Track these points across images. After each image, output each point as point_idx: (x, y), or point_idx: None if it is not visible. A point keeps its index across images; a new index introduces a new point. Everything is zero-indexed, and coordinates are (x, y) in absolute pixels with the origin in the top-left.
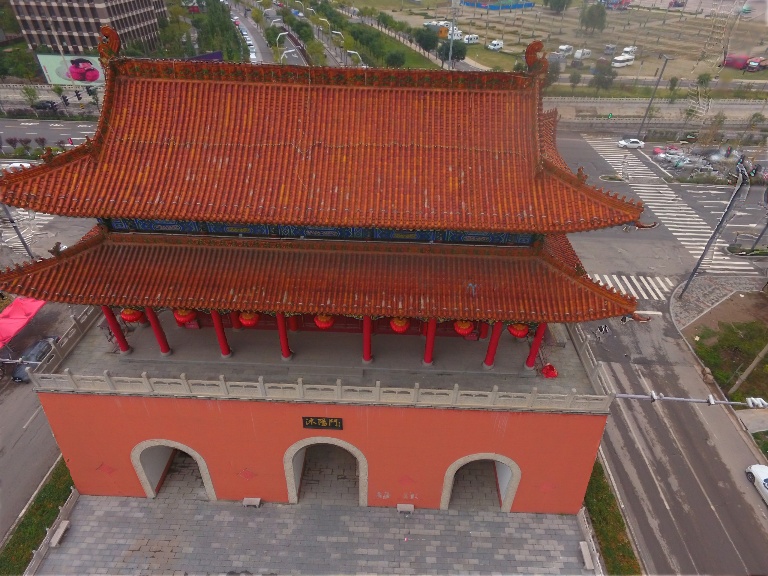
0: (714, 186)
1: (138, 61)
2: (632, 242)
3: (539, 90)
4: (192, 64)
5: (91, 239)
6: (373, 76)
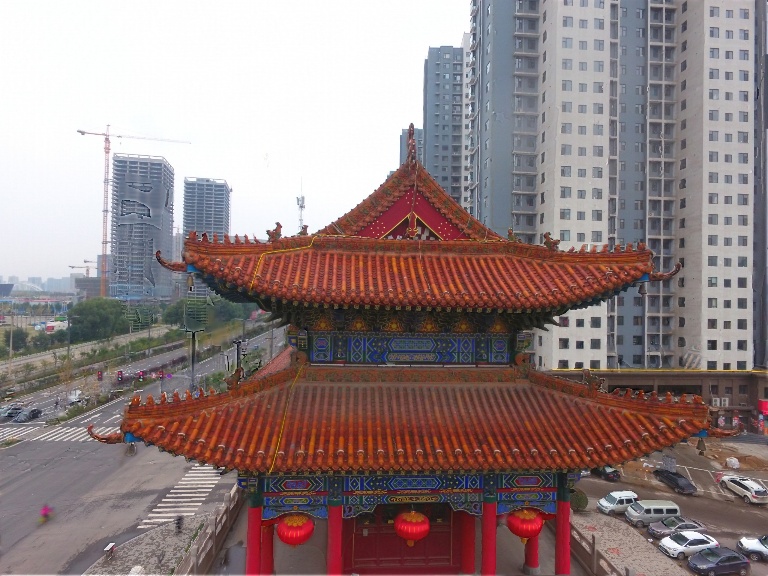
0: (88, 413)
1: None
2: (143, 456)
3: None
4: None
5: (544, 374)
6: None
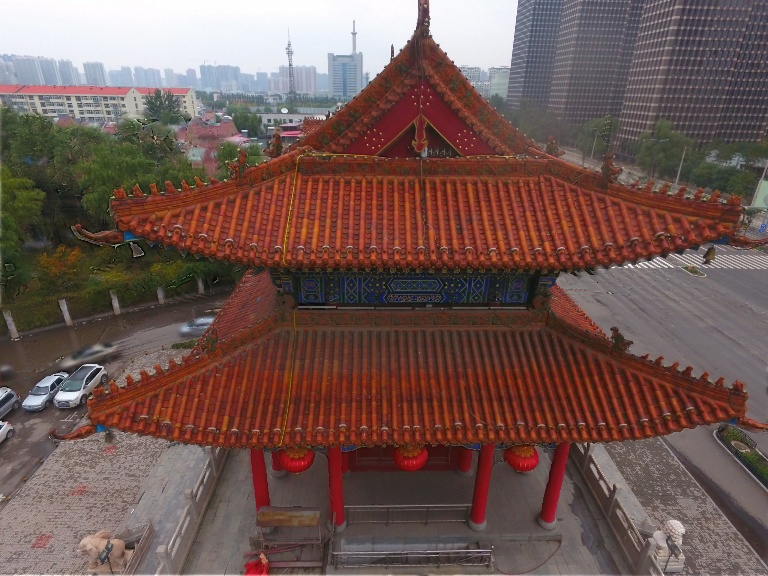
0: None
1: None
2: None
3: (417, 60)
4: None
5: None
6: None
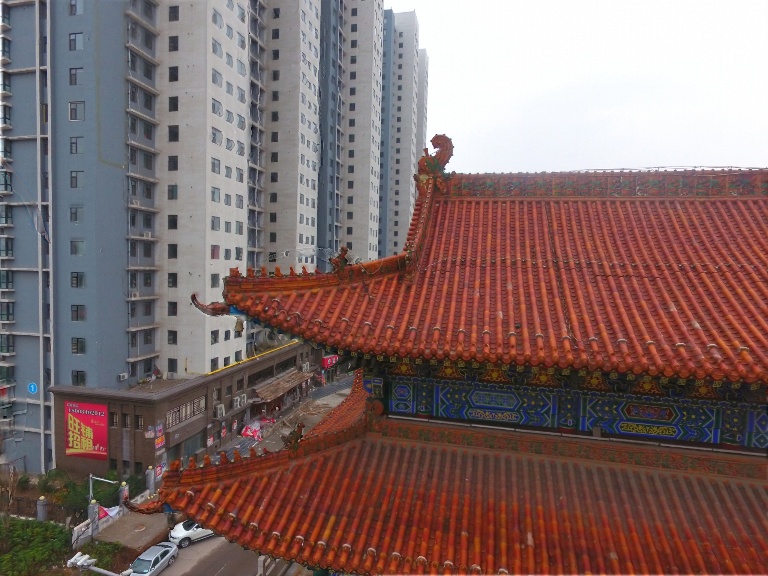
0: None
1: None
2: None
3: None
4: None
5: None
6: (682, 183)
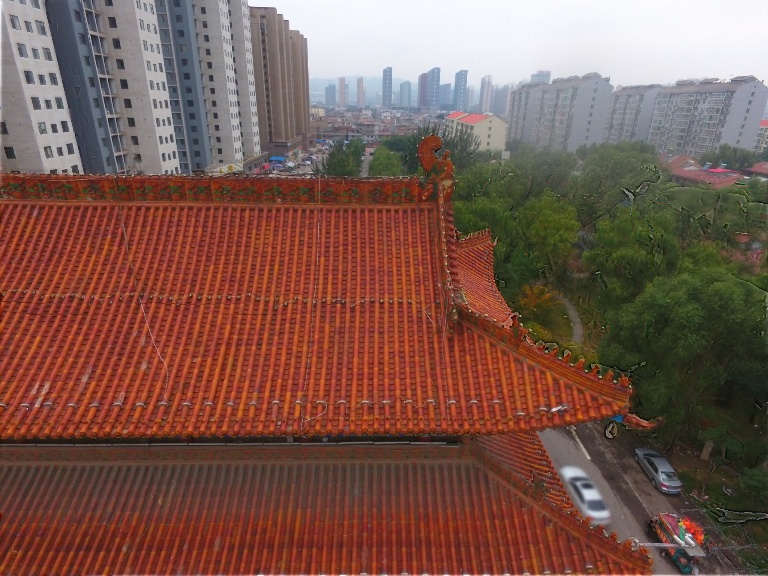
0: None
1: (398, 181)
2: None
3: None
4: (318, 181)
5: None
6: None
